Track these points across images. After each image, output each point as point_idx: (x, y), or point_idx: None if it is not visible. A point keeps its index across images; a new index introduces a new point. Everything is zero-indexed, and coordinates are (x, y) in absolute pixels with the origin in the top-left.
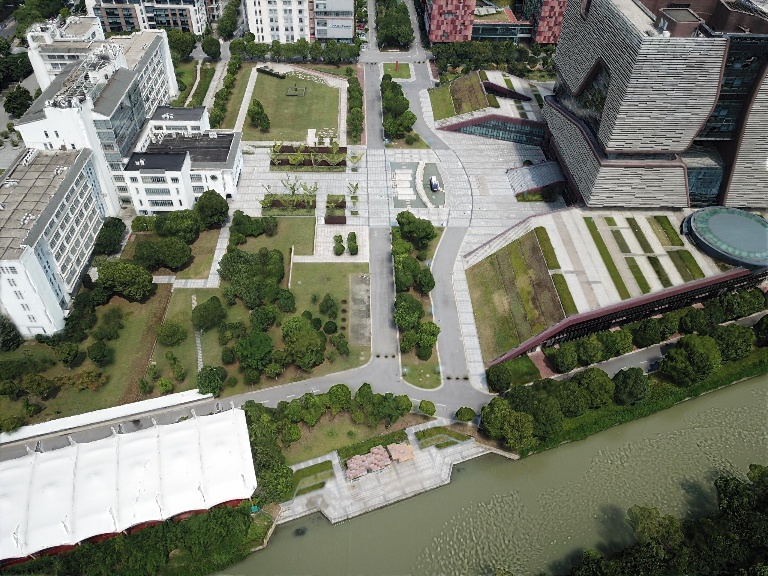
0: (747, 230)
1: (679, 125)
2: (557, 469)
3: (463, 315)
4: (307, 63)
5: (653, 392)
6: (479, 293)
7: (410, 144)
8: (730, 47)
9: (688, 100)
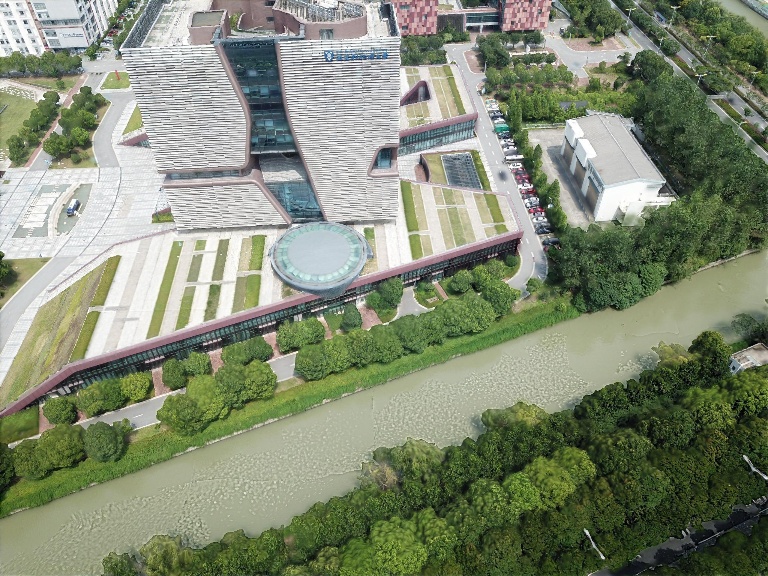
0: (327, 249)
1: (221, 140)
2: (28, 537)
3: (1, 361)
4: (28, 77)
5: (149, 444)
6: (32, 335)
7: (77, 163)
8: (231, 53)
9: (214, 113)
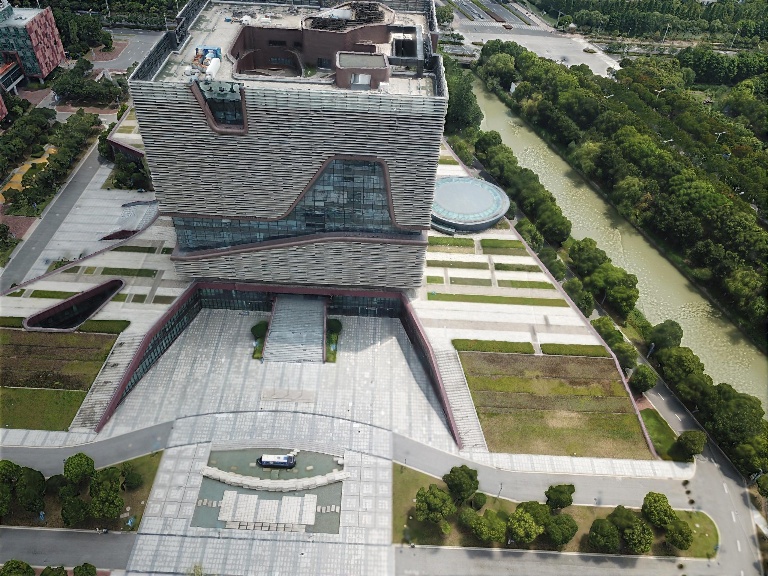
0: (462, 192)
1: None
2: None
3: (579, 469)
4: None
5: None
6: (540, 442)
7: (139, 484)
8: None
9: None
